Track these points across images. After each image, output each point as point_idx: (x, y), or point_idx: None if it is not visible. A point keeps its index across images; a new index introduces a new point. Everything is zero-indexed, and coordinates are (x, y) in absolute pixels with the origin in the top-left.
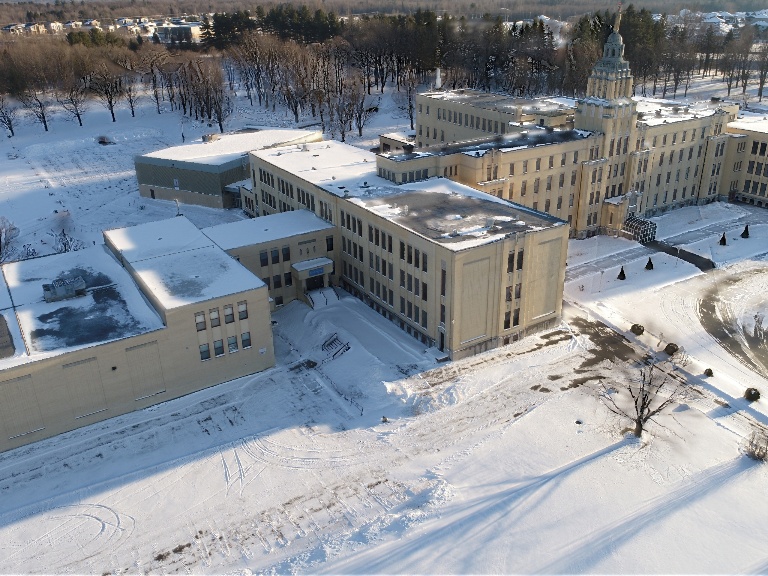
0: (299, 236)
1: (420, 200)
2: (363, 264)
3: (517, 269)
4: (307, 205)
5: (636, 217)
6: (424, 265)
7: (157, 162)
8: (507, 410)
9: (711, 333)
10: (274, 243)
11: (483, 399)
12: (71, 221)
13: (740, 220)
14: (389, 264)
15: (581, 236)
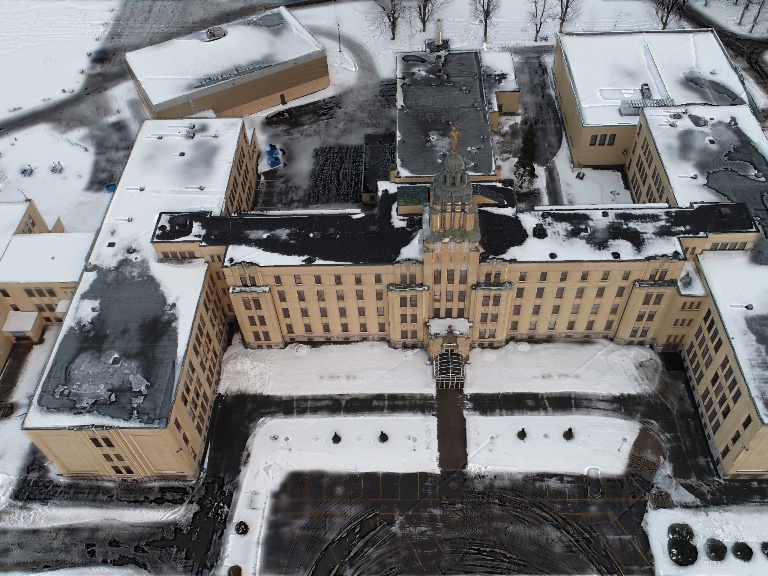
0: (59, 283)
1: (131, 305)
2: None
3: (109, 446)
4: None
5: (453, 356)
6: None
7: None
8: (47, 556)
9: (316, 565)
10: (35, 284)
11: (48, 533)
12: (61, 111)
13: (615, 399)
14: None
15: (394, 345)
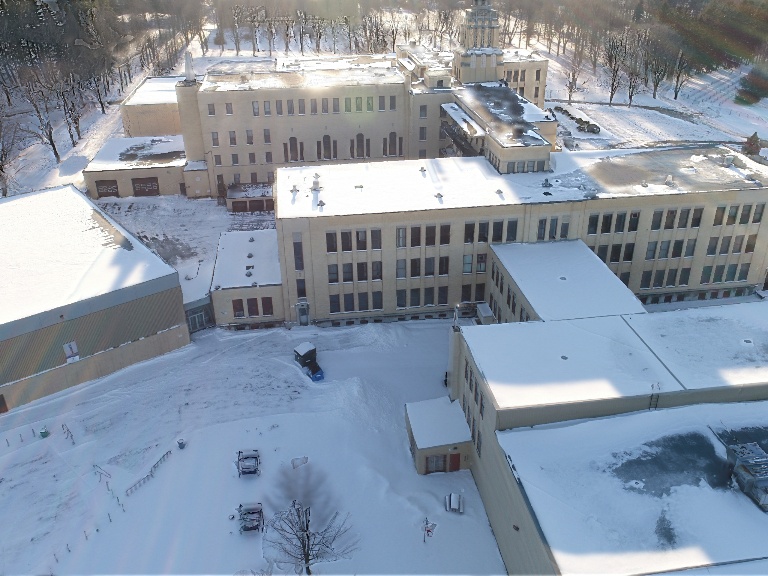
0: None
1: (622, 173)
2: (632, 262)
3: None
4: (493, 239)
5: None
6: (755, 217)
7: (11, 331)
8: None
9: None
10: None
11: None
12: None
13: None
14: (689, 241)
15: None
